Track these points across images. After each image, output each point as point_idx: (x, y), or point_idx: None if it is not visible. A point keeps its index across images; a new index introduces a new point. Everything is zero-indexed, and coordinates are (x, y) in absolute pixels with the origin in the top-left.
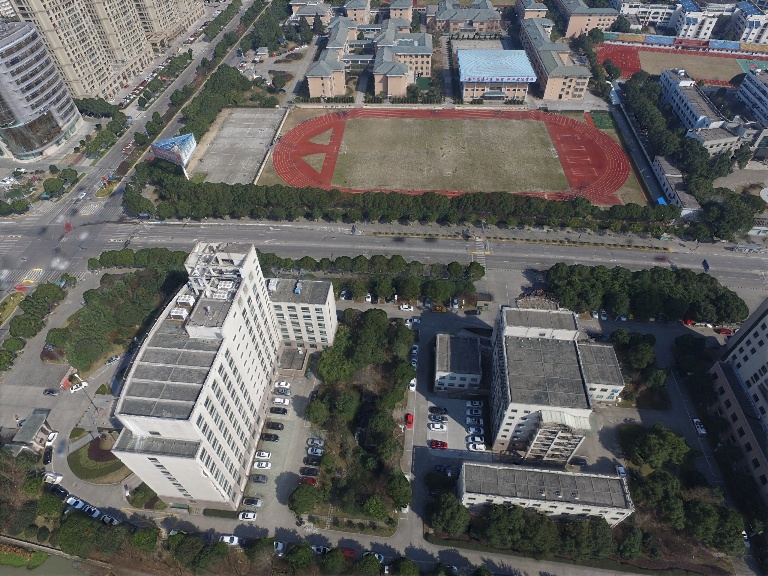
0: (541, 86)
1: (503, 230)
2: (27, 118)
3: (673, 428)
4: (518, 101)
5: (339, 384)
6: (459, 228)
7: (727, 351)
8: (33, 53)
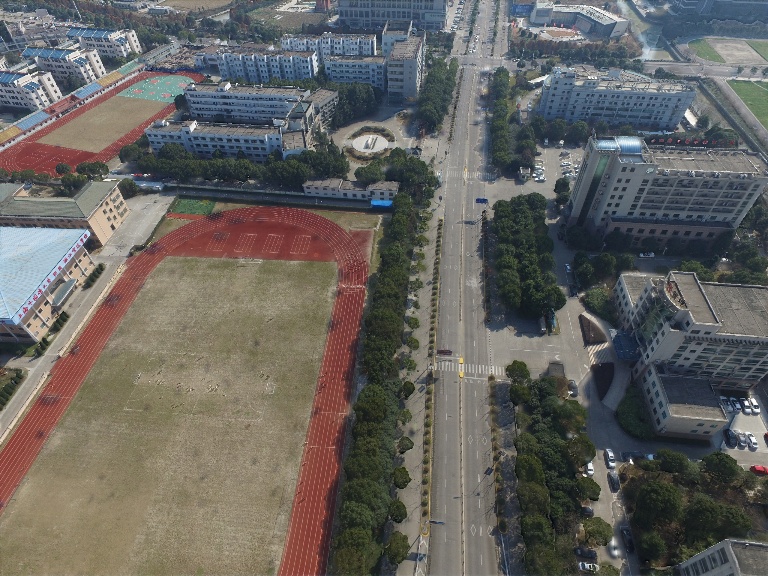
0: None
1: None
2: None
3: (653, 269)
4: (97, 271)
5: None
6: None
7: (579, 218)
8: None
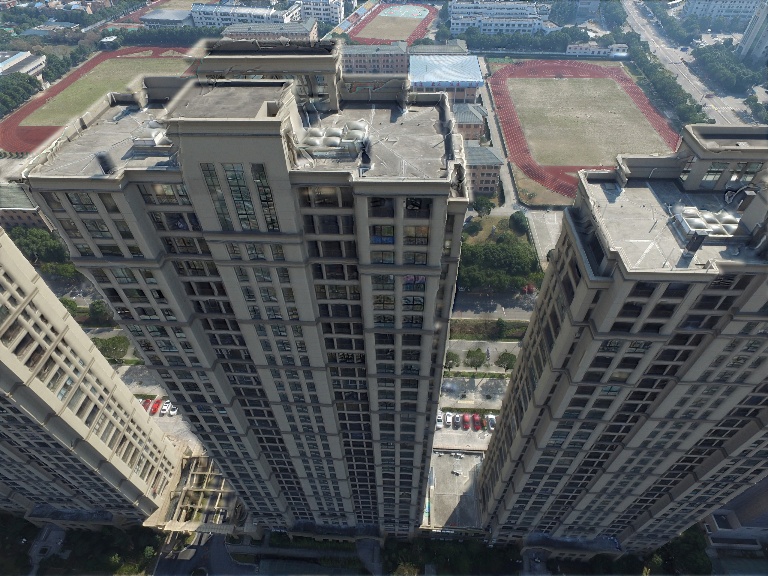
0: None
1: None
2: None
3: None
4: None
5: None
6: None
7: None
8: None
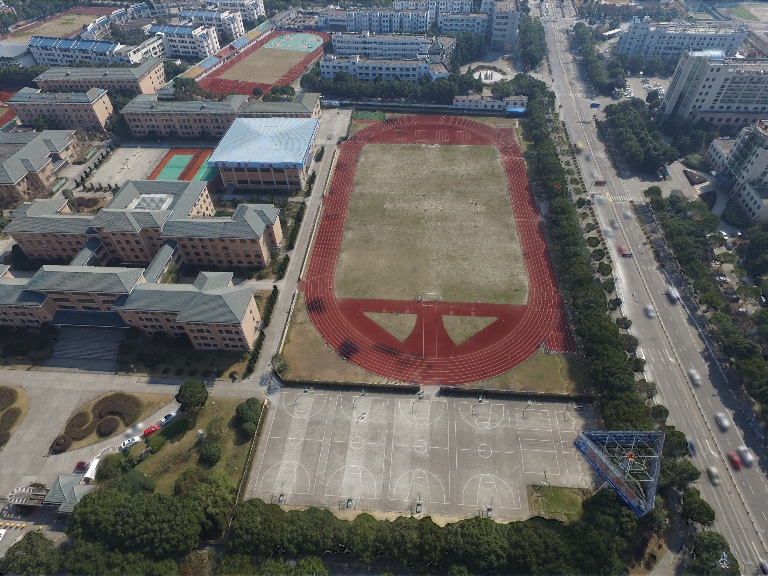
0: None
1: None
2: None
3: None
4: (322, 150)
5: None
6: None
7: (671, 115)
8: None
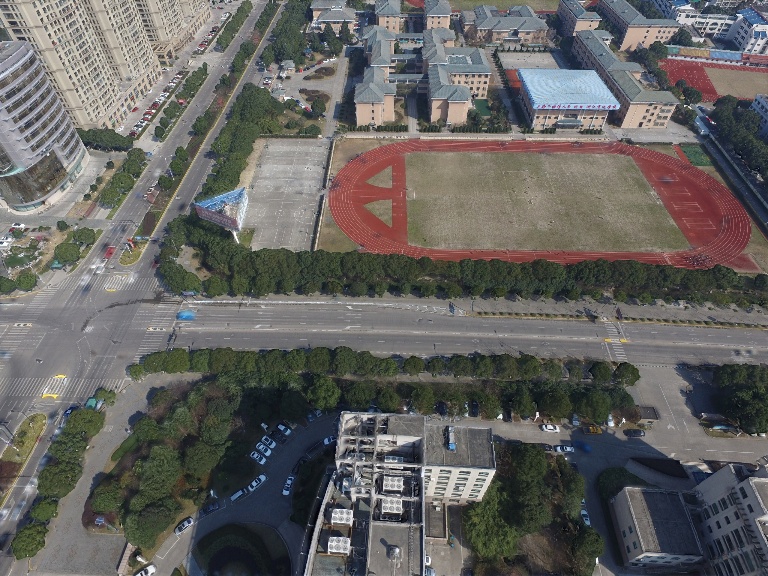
0: (617, 112)
1: (632, 307)
2: (26, 162)
3: None
4: (596, 130)
5: (499, 559)
6: (579, 304)
7: None
8: (32, 81)
